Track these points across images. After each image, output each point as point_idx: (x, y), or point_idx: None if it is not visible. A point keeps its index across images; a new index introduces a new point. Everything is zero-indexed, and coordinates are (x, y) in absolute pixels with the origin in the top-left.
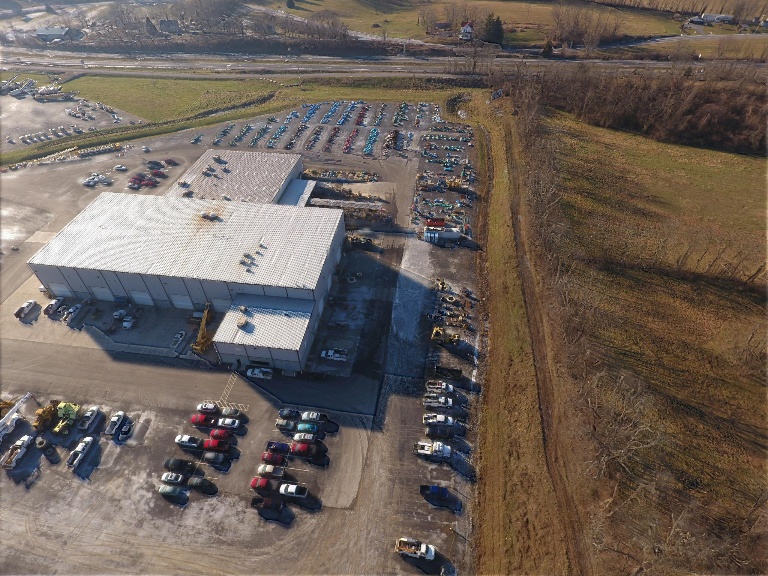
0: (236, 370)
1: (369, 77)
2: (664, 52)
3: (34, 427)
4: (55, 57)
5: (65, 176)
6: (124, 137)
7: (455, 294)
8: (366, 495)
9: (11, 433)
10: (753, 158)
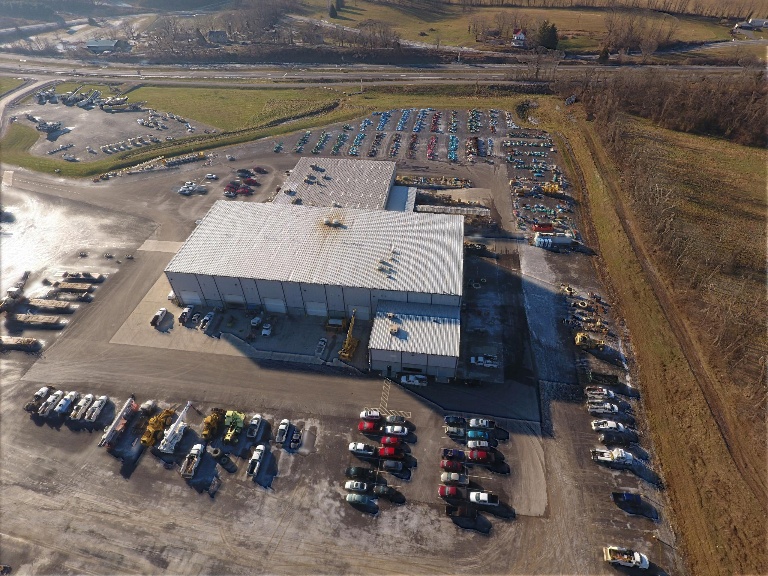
0: (388, 377)
1: (431, 85)
2: (722, 57)
3: (203, 436)
4: (108, 68)
5: (158, 185)
6: (205, 146)
7: (584, 299)
8: (557, 503)
9: (180, 442)
10: None
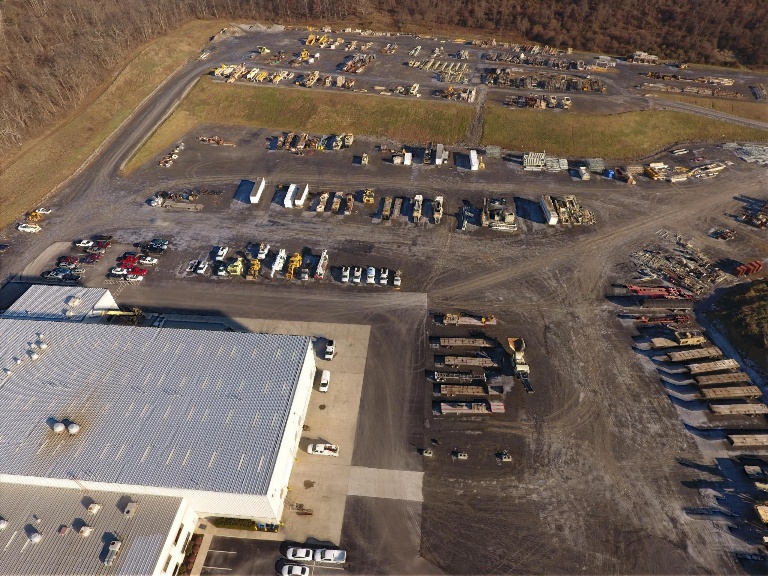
0: None
1: None
2: None
3: None
4: None
5: None
6: None
7: None
8: (43, 246)
9: None
10: None
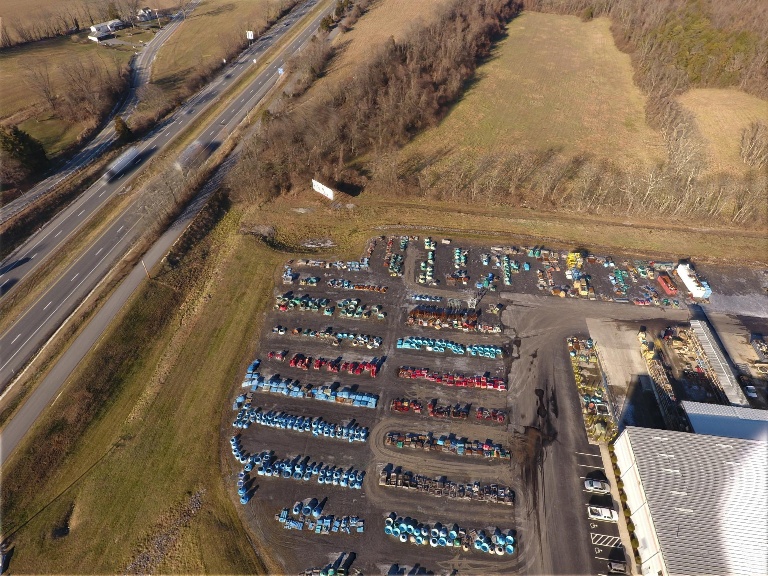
0: None
1: (95, 355)
2: (198, 72)
3: None
4: None
5: None
6: None
7: None
8: None
9: None
10: (467, 100)
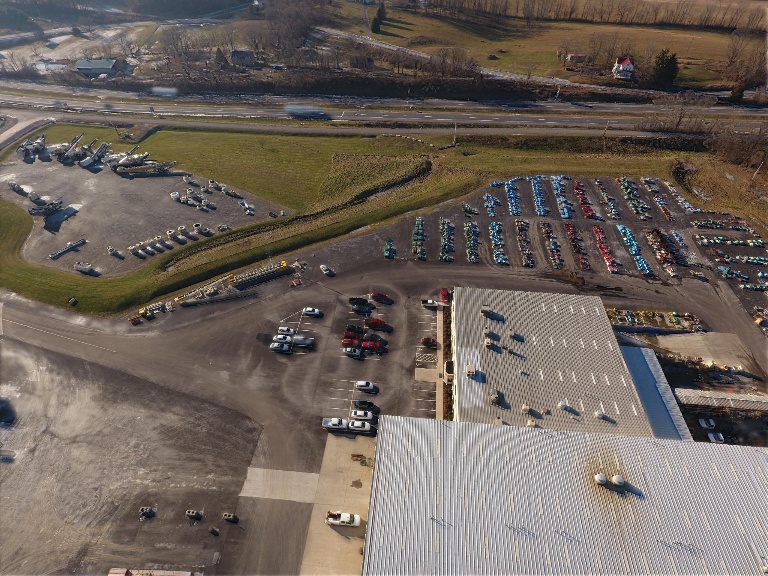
0: None
1: (544, 135)
2: None
3: None
4: (108, 99)
5: (234, 330)
6: (283, 246)
7: None
8: None
9: None
10: None
